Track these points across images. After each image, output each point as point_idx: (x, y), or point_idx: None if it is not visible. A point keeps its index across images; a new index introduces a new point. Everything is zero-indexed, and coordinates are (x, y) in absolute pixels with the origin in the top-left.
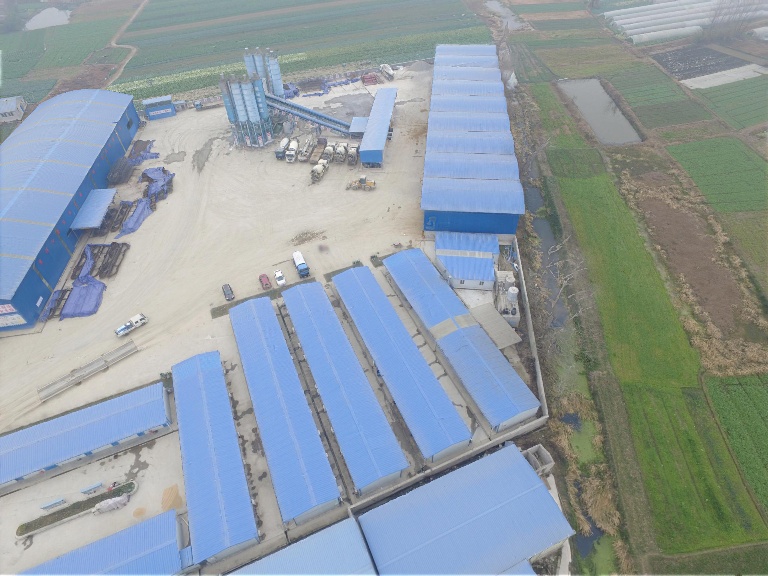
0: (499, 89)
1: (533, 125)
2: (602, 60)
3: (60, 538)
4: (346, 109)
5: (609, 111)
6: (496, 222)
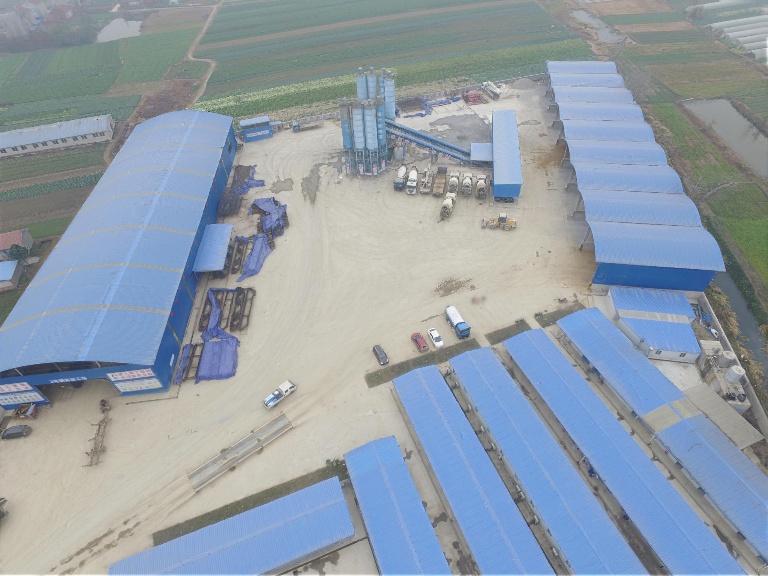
0: (637, 114)
1: (672, 153)
2: (725, 78)
3: None
4: (455, 132)
5: (747, 136)
6: (684, 278)
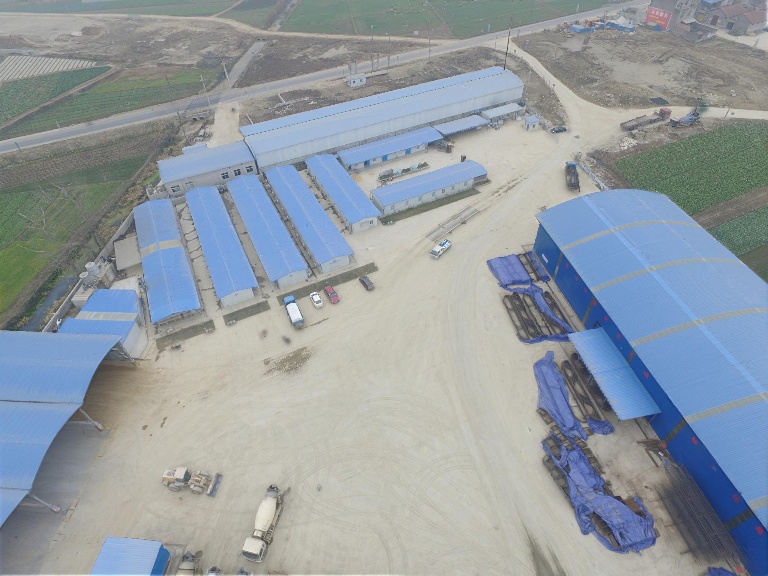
0: None
1: None
2: None
3: (406, 166)
4: None
5: None
6: None
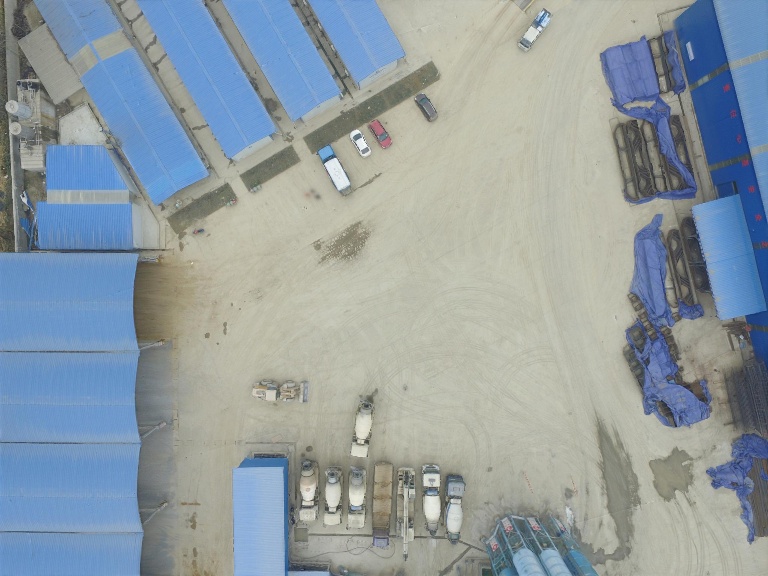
0: None
1: None
2: None
3: None
4: None
5: None
6: None
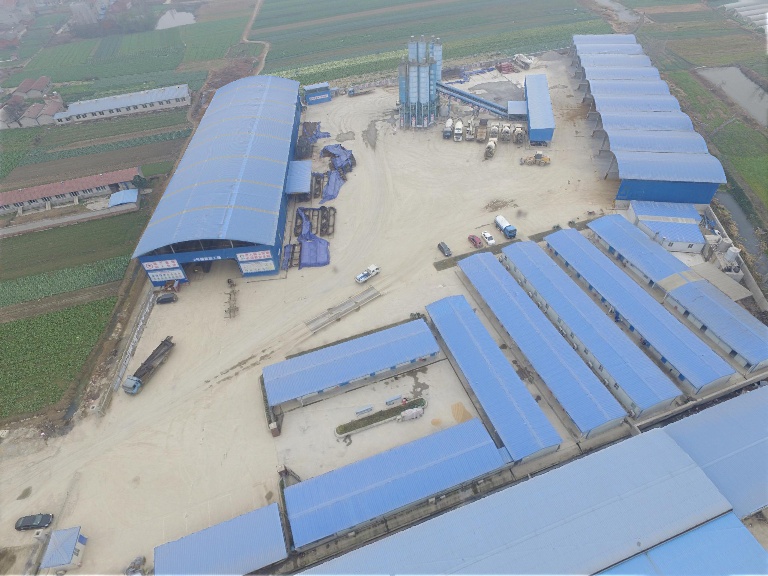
0: (654, 73)
1: (685, 109)
2: (736, 49)
3: (374, 438)
4: (492, 95)
5: (754, 97)
6: (693, 191)
